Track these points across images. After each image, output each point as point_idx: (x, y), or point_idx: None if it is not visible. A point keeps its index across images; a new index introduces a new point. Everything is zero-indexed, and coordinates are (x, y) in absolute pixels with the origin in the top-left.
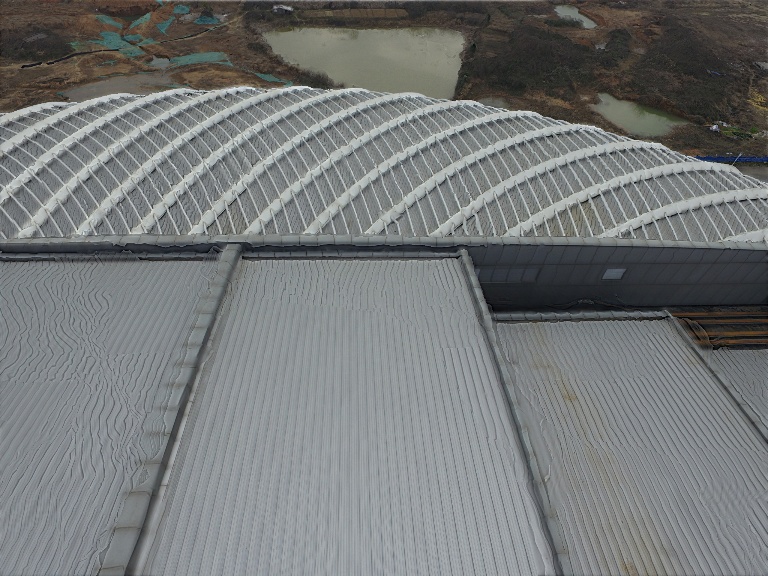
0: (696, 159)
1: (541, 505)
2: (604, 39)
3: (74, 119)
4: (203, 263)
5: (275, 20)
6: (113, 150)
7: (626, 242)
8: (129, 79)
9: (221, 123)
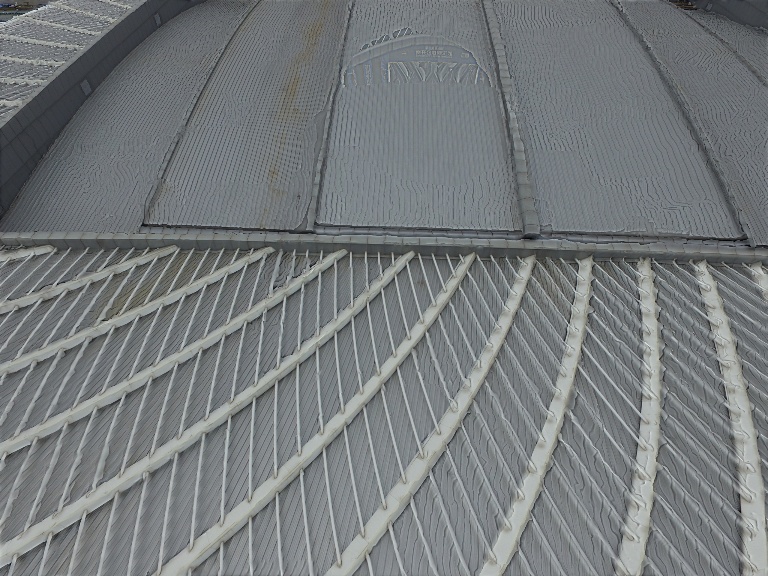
0: None
1: (338, 77)
2: None
3: None
4: None
5: None
6: None
7: (136, 237)
8: None
9: None
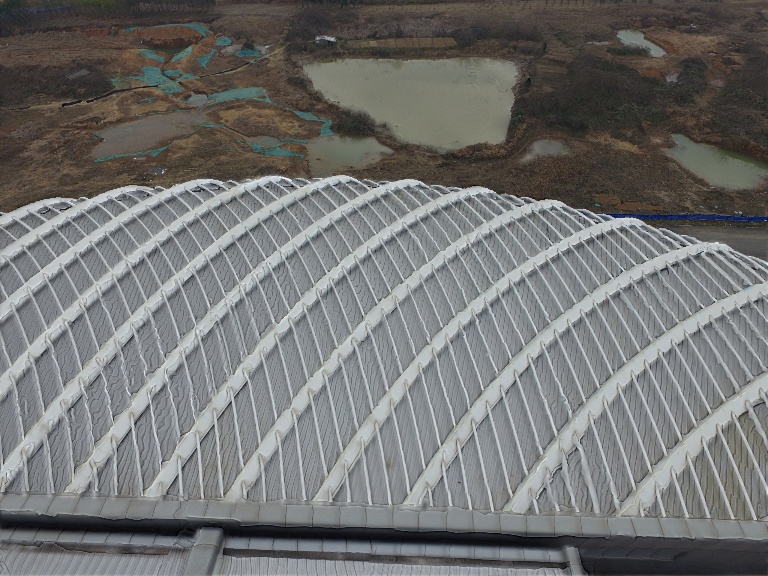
0: None
1: None
2: (675, 69)
3: (54, 237)
4: (162, 563)
5: (317, 52)
6: (85, 300)
7: None
8: (165, 118)
9: (229, 249)
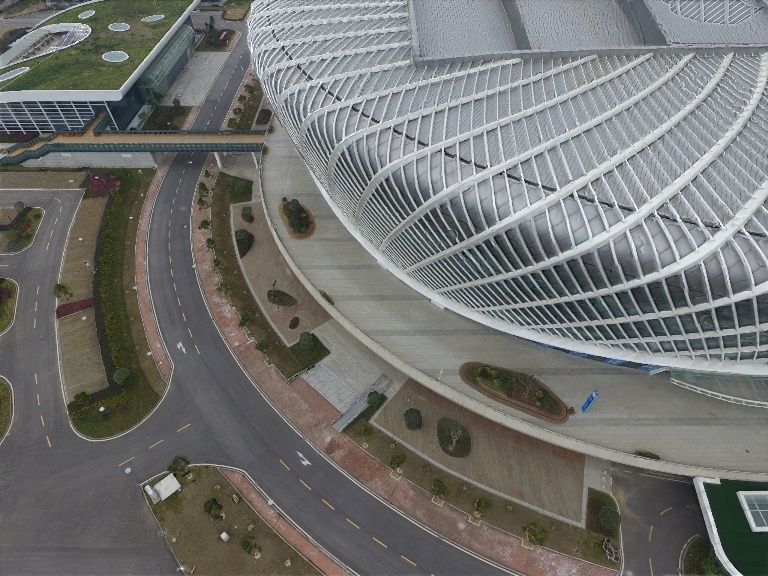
0: (444, 162)
1: None
2: None
3: None
4: None
5: None
6: None
7: (574, 50)
8: None
9: None
